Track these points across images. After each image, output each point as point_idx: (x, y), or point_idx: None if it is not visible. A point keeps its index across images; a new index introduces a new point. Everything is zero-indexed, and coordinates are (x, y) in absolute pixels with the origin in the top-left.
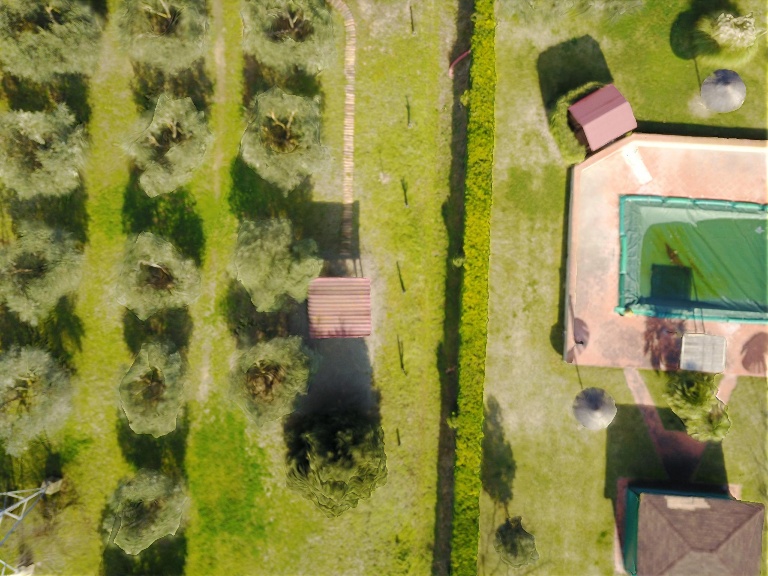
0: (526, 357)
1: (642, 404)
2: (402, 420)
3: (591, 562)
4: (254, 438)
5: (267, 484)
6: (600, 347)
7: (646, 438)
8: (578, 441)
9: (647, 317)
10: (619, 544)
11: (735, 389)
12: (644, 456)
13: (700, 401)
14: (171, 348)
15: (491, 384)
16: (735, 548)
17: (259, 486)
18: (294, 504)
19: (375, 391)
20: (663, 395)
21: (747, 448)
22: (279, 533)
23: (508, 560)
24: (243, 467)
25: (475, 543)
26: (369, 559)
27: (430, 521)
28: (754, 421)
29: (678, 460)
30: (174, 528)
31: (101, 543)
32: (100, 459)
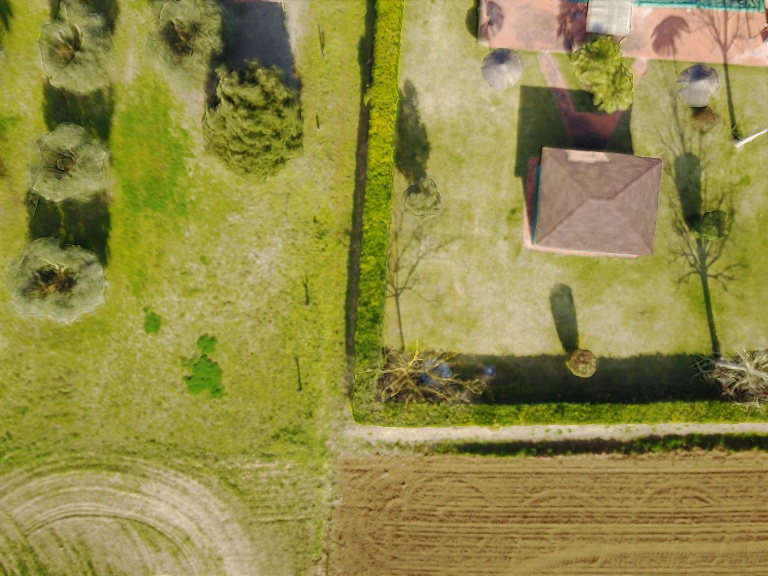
0: (442, 41)
1: (554, 87)
2: (322, 107)
3: (500, 237)
4: (177, 119)
5: (189, 164)
6: (514, 30)
7: (557, 120)
8: (490, 122)
9: (560, 1)
10: (527, 221)
11: (645, 73)
12: (554, 137)
13: (602, 58)
14: (91, 9)
15: (408, 69)
16: (631, 199)
17: (181, 165)
18: (215, 184)
19: (296, 78)
20: (570, 63)
21: (654, 129)
22: (200, 210)
23: (411, 203)
24: (166, 146)
25: (385, 207)
26: (287, 238)
27: (348, 208)
28: (662, 104)
29: (587, 141)
30: (93, 184)
31: (27, 214)
32: (27, 135)
